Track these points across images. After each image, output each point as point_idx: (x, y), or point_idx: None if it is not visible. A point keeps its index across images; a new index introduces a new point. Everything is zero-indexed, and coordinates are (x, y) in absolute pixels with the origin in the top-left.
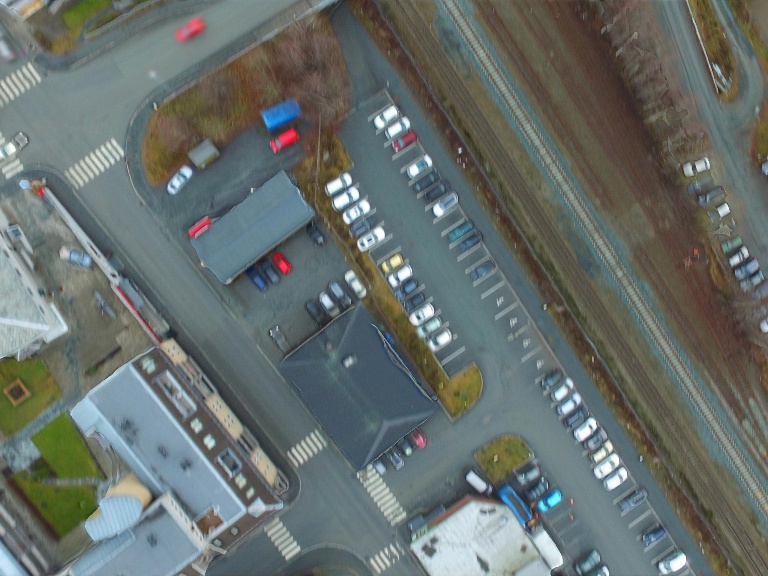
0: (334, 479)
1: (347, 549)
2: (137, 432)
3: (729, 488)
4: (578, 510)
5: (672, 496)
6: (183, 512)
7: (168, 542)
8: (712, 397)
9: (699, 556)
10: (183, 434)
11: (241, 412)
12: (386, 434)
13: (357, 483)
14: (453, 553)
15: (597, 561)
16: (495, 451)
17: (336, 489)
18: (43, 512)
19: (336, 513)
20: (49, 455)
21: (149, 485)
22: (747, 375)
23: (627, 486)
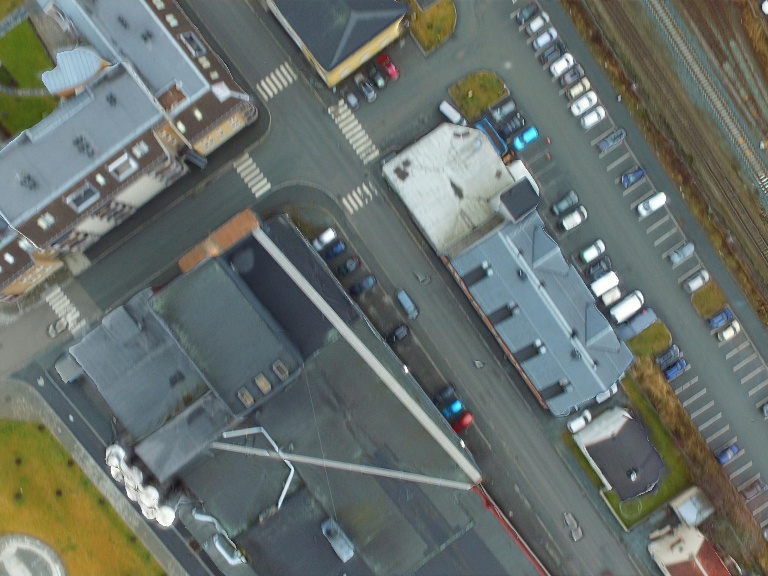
0: (305, 114)
1: (318, 187)
2: (96, 2)
3: (710, 132)
4: (555, 150)
5: (651, 138)
6: (144, 85)
7: (128, 103)
8: (692, 38)
9: (679, 200)
10: (144, 5)
11: (209, 40)
12: (355, 28)
13: (328, 119)
14: (426, 177)
15: (575, 201)
16: (470, 86)
17: (307, 124)
18: (4, 122)
19: (307, 149)
20: (10, 64)
21: (109, 58)
22: (728, 16)
23: (605, 127)
